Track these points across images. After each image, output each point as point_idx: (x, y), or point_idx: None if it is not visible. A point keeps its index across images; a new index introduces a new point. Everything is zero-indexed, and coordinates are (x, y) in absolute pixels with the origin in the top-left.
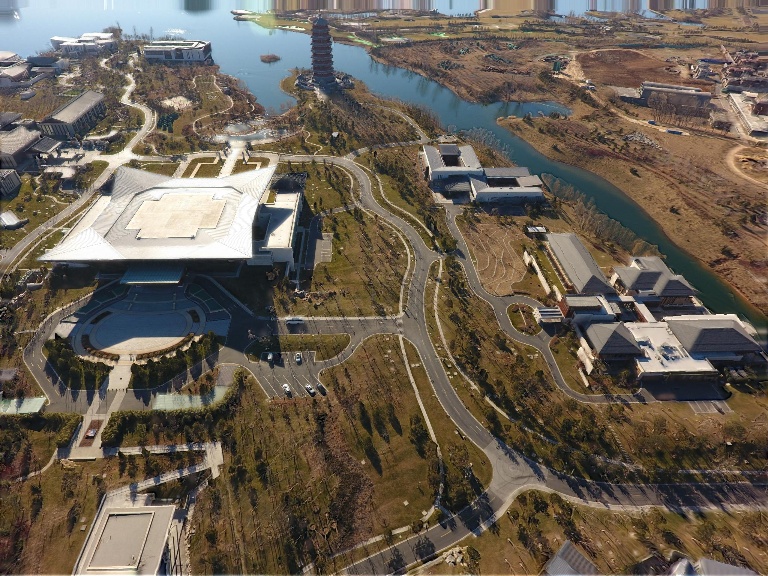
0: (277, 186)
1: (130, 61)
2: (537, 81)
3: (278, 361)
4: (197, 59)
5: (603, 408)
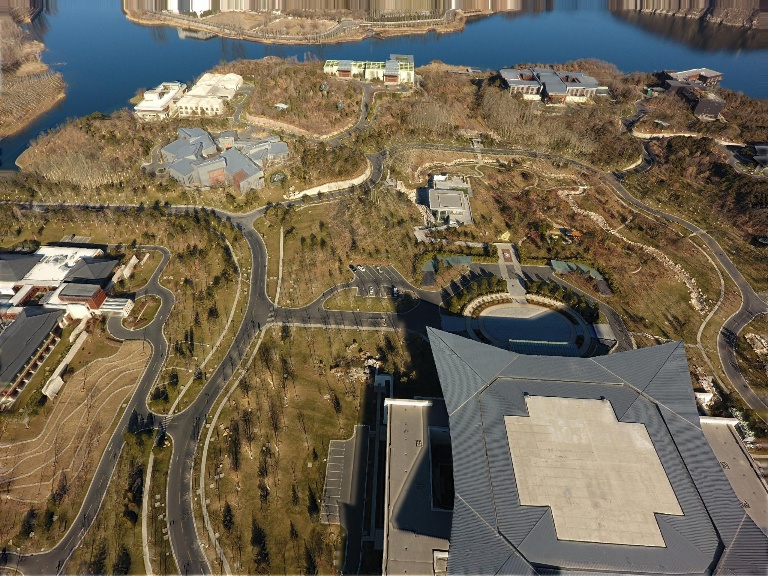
0: None
1: None
2: None
3: None
4: None
5: None
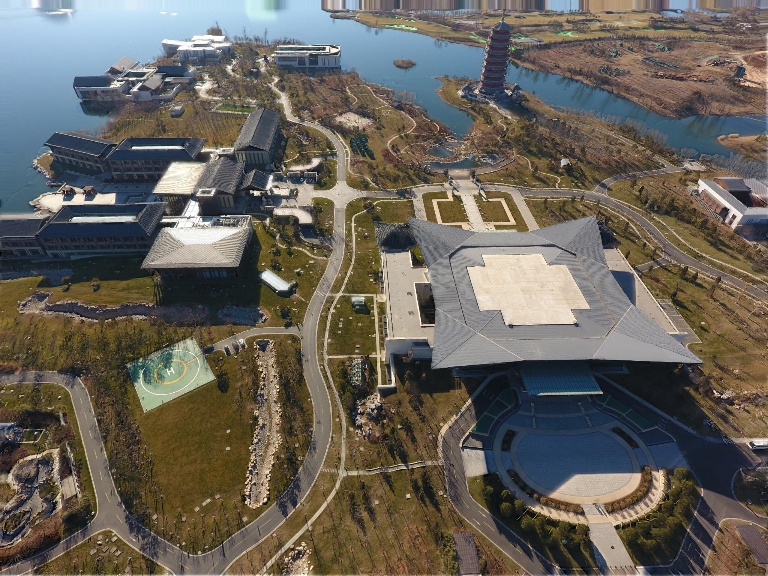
0: None
1: (261, 68)
2: (727, 90)
3: None
4: (333, 65)
5: None
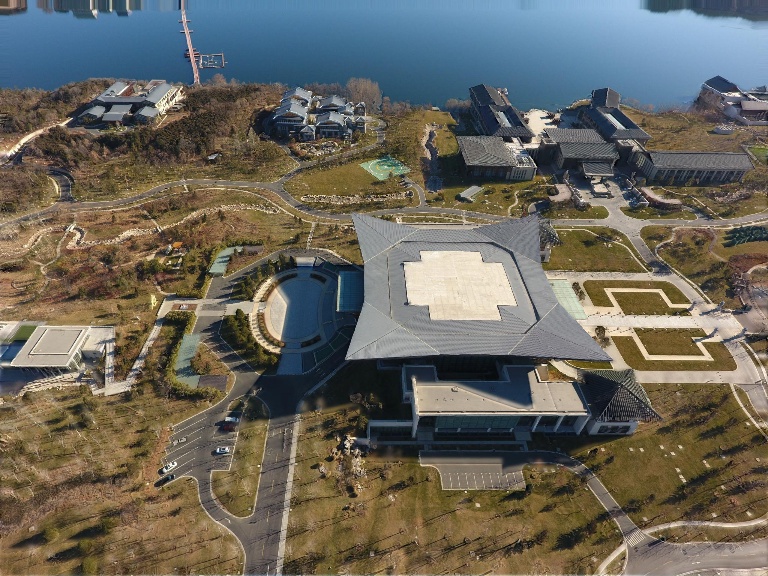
0: (590, 378)
1: None
2: None
3: (223, 429)
4: None
5: None
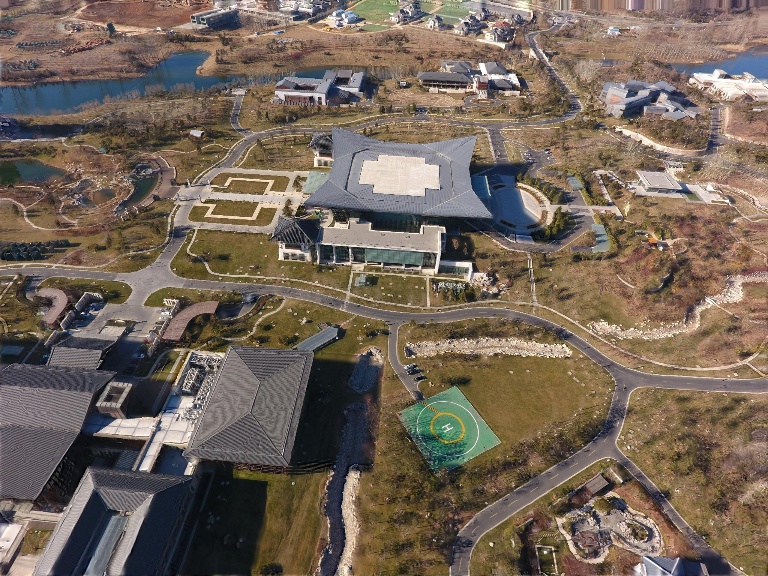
0: None
1: None
2: (129, 43)
3: None
4: None
5: (548, 90)
